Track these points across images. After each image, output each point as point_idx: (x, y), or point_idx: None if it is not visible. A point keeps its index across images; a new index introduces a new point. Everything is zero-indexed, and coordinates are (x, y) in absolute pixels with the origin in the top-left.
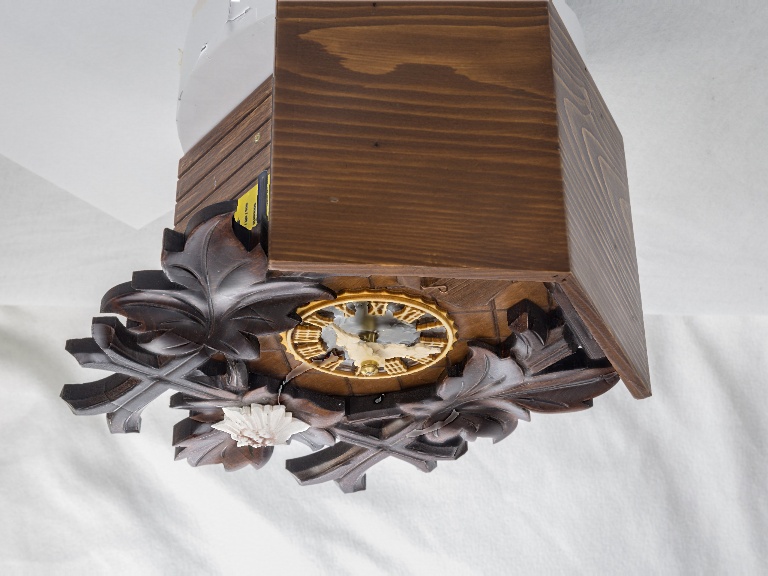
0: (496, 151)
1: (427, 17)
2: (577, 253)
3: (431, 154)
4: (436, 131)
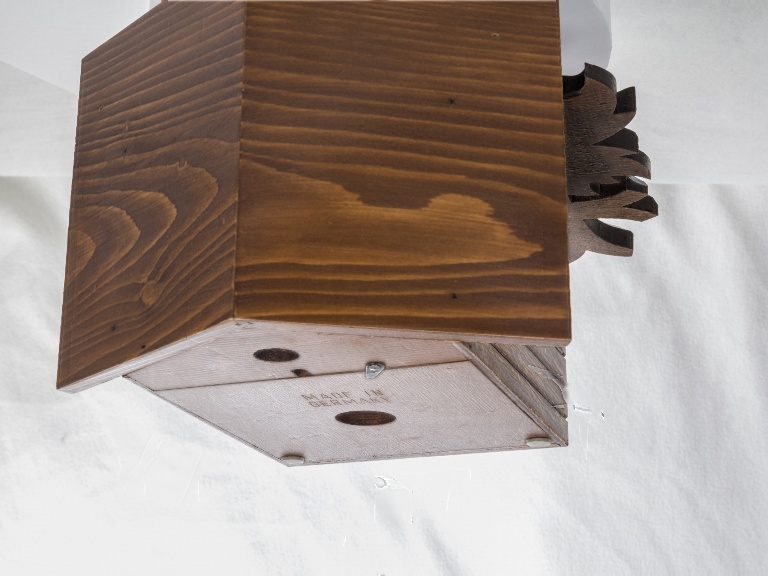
0: (318, 89)
1: (390, 277)
2: None
3: (392, 88)
4: (385, 117)
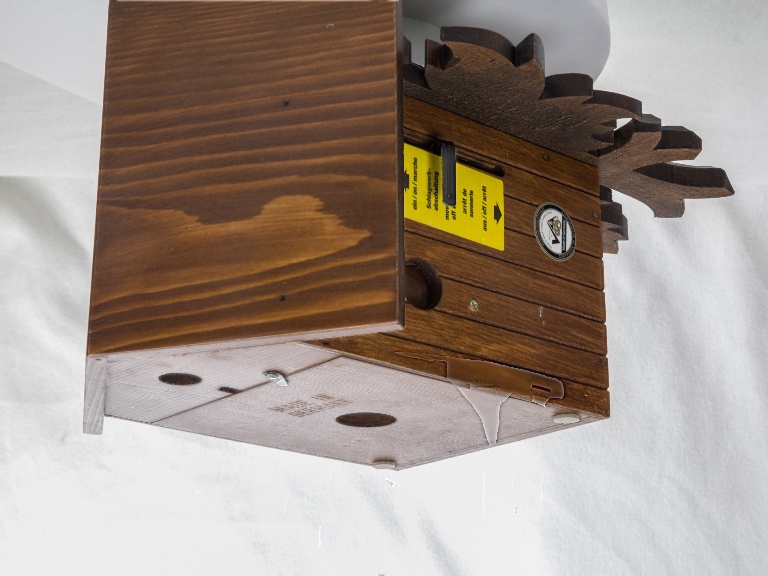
0: (165, 123)
1: (224, 291)
2: None
3: (231, 104)
4: (224, 134)
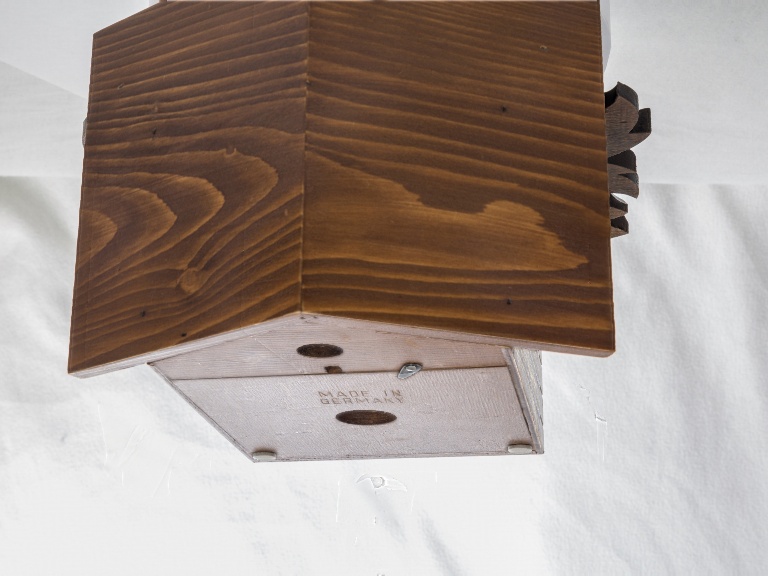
0: (379, 87)
1: (449, 280)
2: None
3: (448, 91)
4: (442, 119)
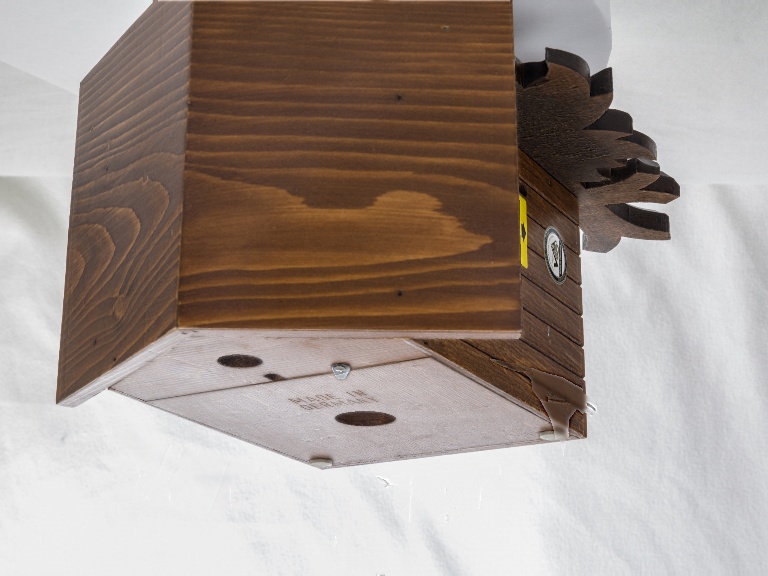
0: (263, 96)
1: (334, 278)
2: (180, 7)
3: (338, 89)
4: (331, 118)
